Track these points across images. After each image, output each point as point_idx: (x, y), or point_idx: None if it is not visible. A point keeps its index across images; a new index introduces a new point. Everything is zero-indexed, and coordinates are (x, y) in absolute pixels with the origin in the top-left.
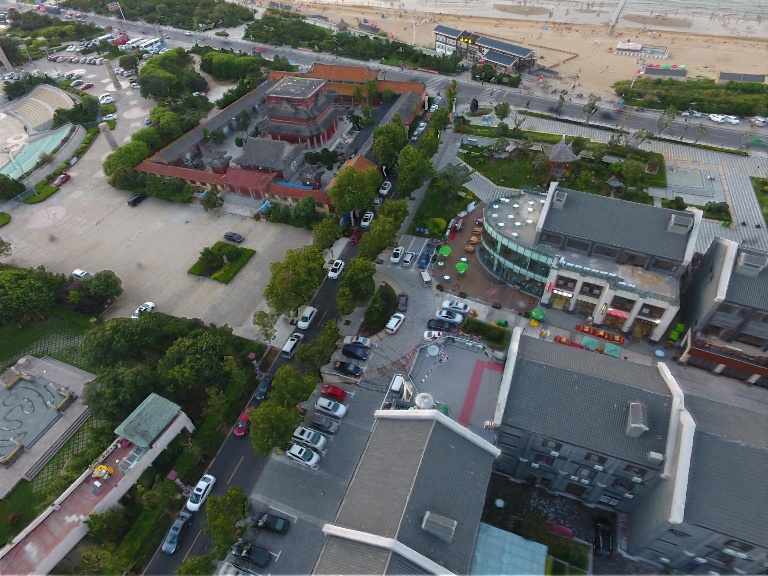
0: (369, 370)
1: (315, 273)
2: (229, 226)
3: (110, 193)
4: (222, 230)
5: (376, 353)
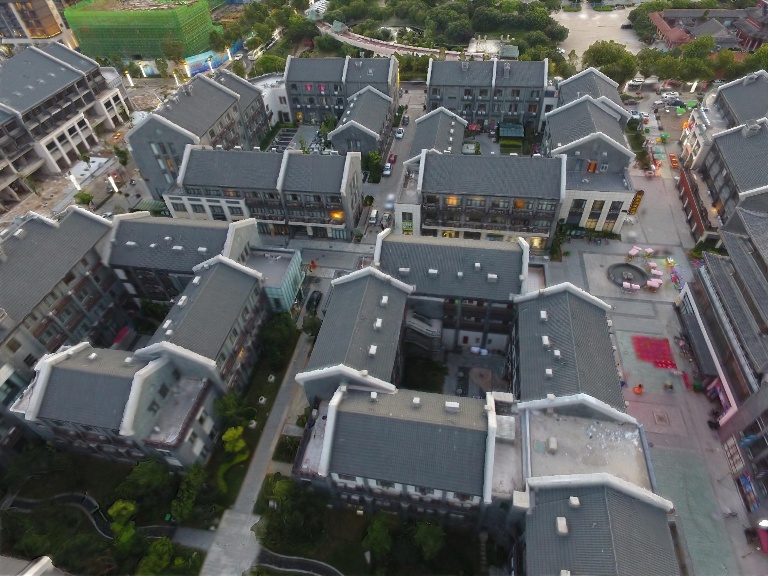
0: None
1: (612, 55)
2: (637, 52)
3: (625, 21)
4: (632, 52)
5: None
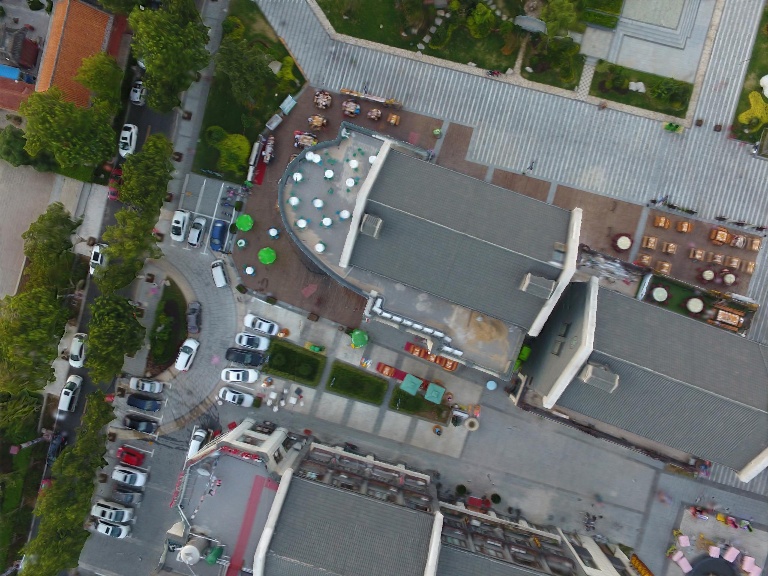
0: (166, 422)
1: (45, 342)
2: None
3: None
4: None
5: (171, 398)
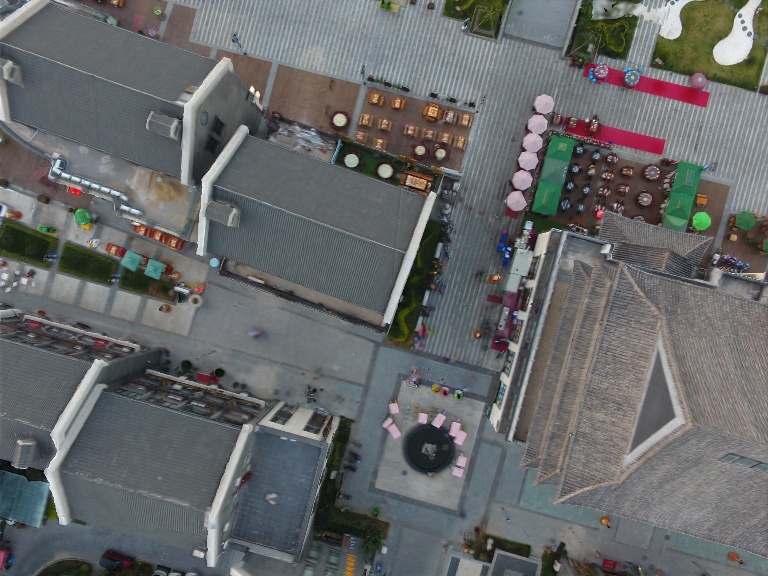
0: None
1: None
2: None
3: None
4: None
5: None
